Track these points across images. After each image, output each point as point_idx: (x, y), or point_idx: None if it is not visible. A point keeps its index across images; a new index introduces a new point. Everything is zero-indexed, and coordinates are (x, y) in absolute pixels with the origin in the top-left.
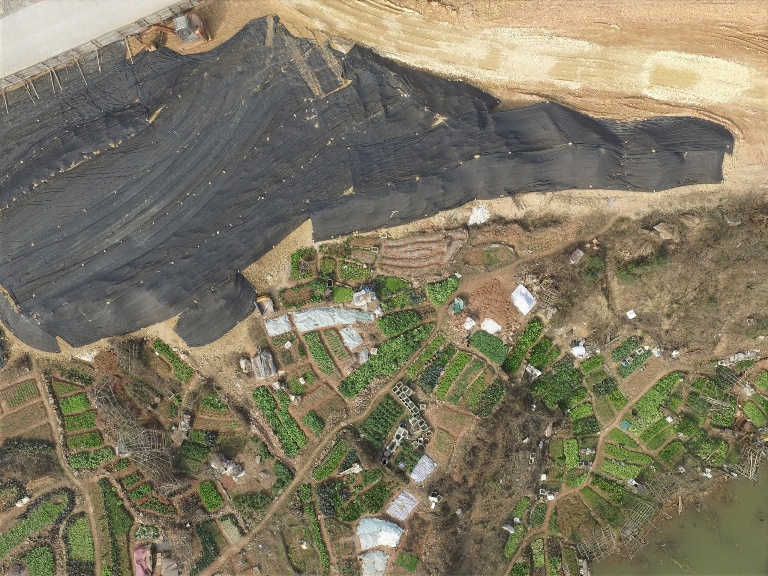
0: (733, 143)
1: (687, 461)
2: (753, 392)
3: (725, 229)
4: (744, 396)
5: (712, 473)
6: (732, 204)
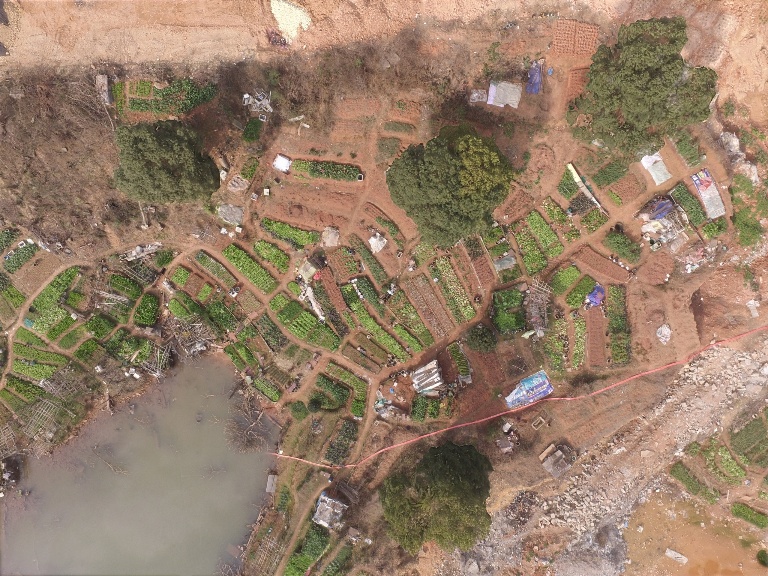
0: (2, 11)
1: (108, 361)
2: (170, 288)
3: (6, 101)
4: (169, 294)
5: (138, 373)
6: (23, 77)
